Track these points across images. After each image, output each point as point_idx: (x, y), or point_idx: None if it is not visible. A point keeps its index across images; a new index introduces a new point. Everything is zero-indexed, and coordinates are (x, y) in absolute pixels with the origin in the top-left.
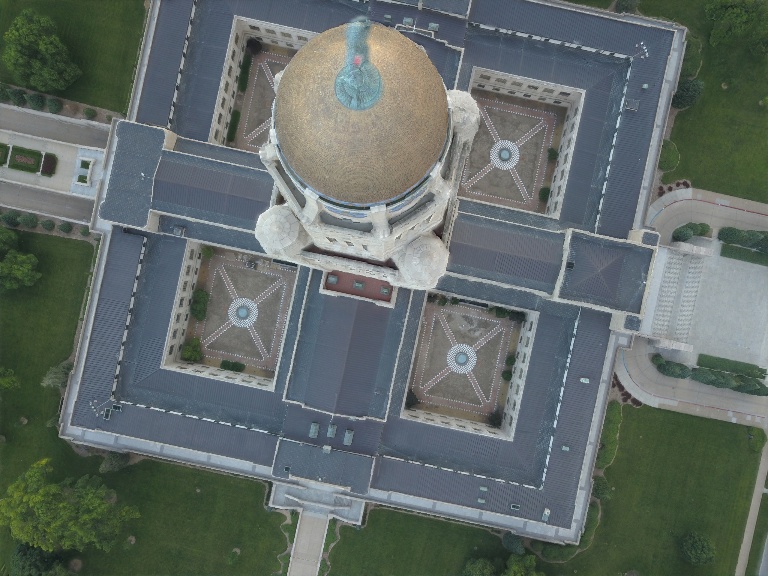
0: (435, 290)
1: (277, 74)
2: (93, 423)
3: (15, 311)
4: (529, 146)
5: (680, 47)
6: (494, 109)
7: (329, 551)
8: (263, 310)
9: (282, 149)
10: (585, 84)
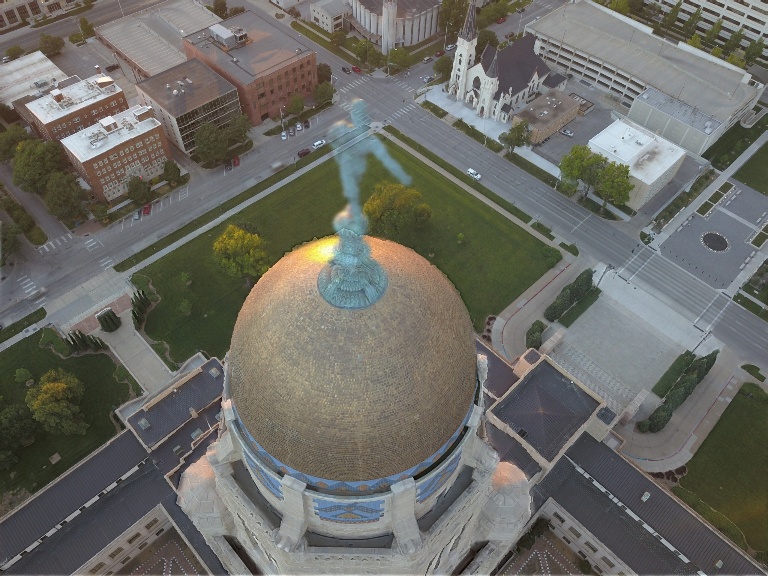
0: None
1: (207, 454)
2: None
3: None
4: None
5: None
6: None
7: None
8: None
9: (325, 471)
10: None
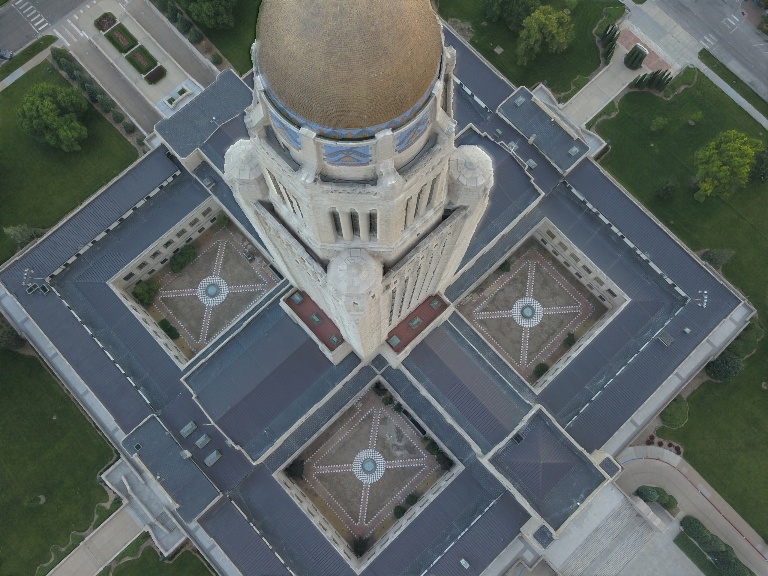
0: (385, 381)
1: None
2: (15, 288)
3: (38, 164)
4: (554, 319)
5: (741, 323)
6: (543, 268)
7: (120, 562)
8: (230, 300)
9: None
10: (634, 294)
